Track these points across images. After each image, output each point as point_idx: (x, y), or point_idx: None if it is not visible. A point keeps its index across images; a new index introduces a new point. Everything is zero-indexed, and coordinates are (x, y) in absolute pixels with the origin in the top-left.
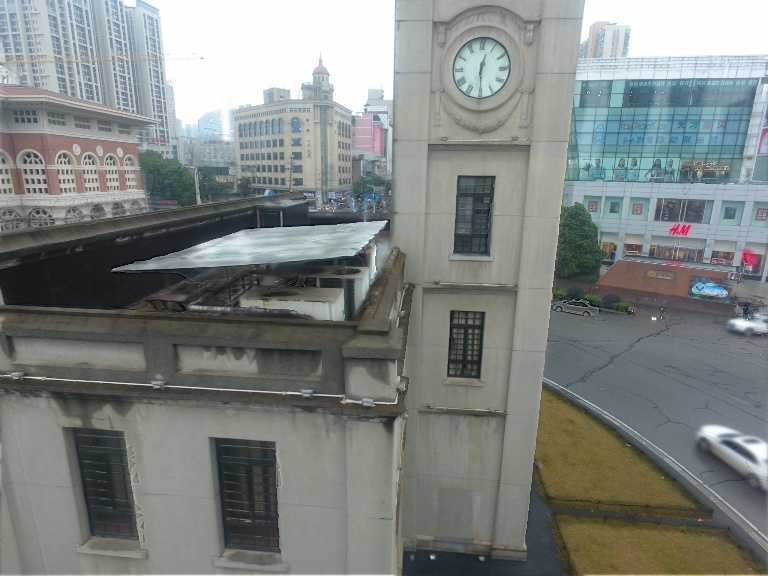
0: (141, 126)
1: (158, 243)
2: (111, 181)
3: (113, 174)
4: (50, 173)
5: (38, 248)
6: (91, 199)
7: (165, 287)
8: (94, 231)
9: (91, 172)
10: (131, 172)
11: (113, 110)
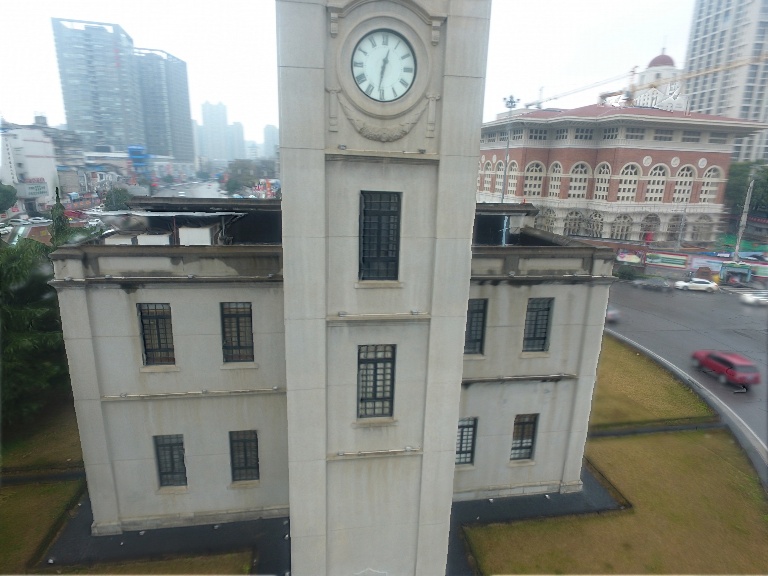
0: (744, 133)
1: (248, 216)
2: (680, 192)
3: (686, 185)
4: (612, 182)
5: (160, 204)
6: (646, 208)
7: (252, 242)
8: (197, 202)
9: (658, 183)
10: (712, 184)
11: (700, 119)
